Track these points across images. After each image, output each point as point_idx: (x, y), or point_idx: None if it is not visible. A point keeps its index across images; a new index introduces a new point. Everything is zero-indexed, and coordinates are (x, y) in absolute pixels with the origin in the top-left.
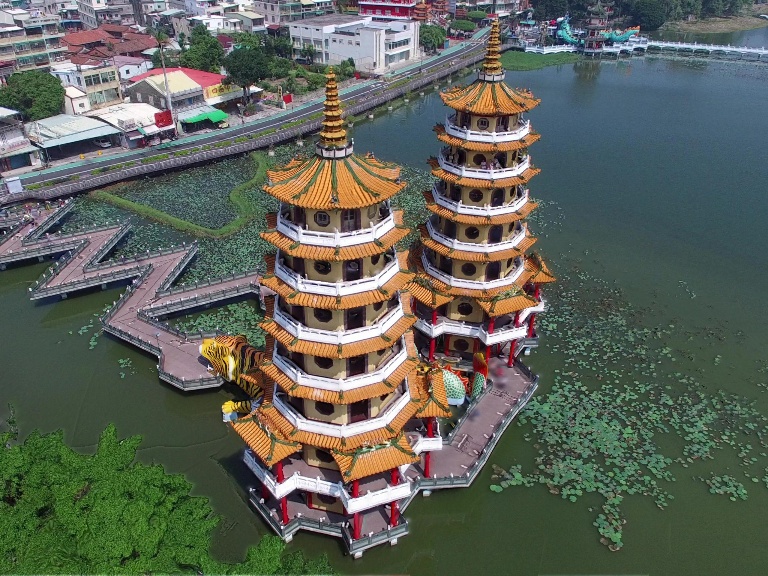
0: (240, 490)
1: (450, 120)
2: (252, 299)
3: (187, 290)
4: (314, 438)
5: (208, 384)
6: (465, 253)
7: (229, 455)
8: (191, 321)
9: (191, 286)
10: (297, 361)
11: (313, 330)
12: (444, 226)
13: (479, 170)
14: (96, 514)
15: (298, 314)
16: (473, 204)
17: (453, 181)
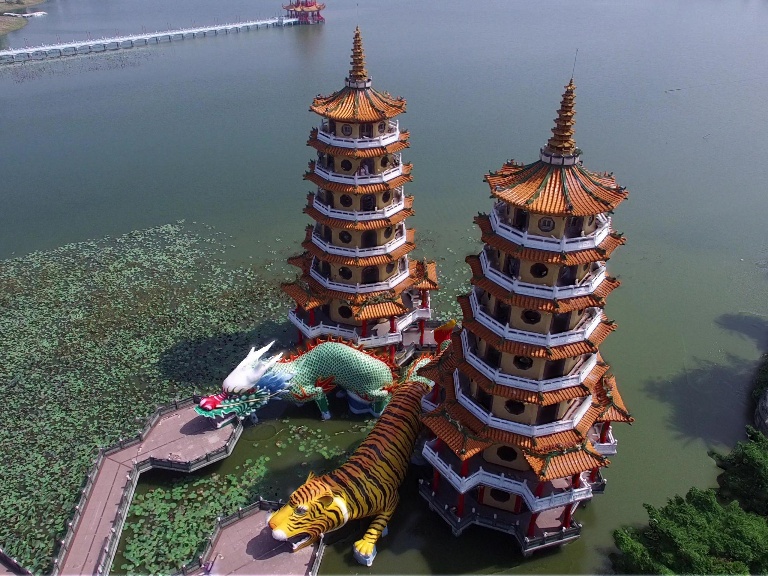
0: (485, 572)
1: (341, 137)
2: (137, 485)
3: (68, 546)
4: (586, 422)
5: (319, 557)
6: (396, 252)
7: (429, 571)
8: (126, 568)
9: (68, 537)
10: (548, 376)
11: (575, 329)
12: (360, 241)
13: (392, 170)
14: (765, 545)
15: (553, 329)
16: (385, 205)
17: (385, 189)
